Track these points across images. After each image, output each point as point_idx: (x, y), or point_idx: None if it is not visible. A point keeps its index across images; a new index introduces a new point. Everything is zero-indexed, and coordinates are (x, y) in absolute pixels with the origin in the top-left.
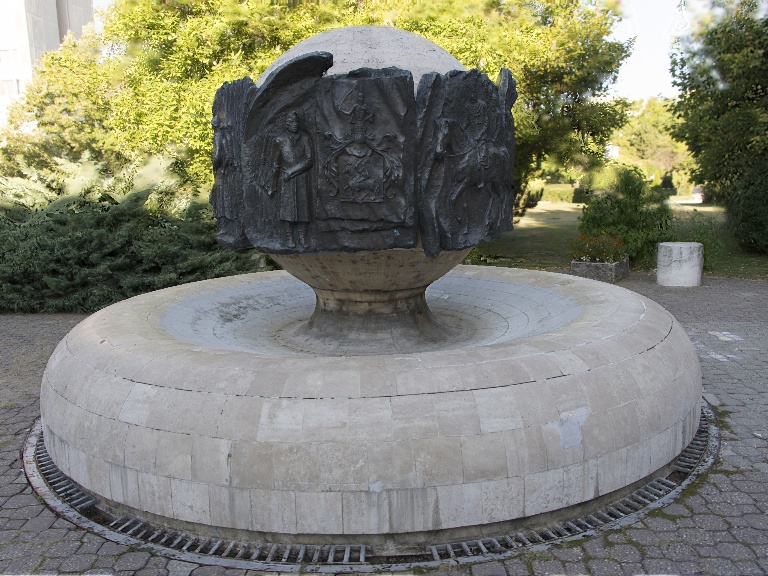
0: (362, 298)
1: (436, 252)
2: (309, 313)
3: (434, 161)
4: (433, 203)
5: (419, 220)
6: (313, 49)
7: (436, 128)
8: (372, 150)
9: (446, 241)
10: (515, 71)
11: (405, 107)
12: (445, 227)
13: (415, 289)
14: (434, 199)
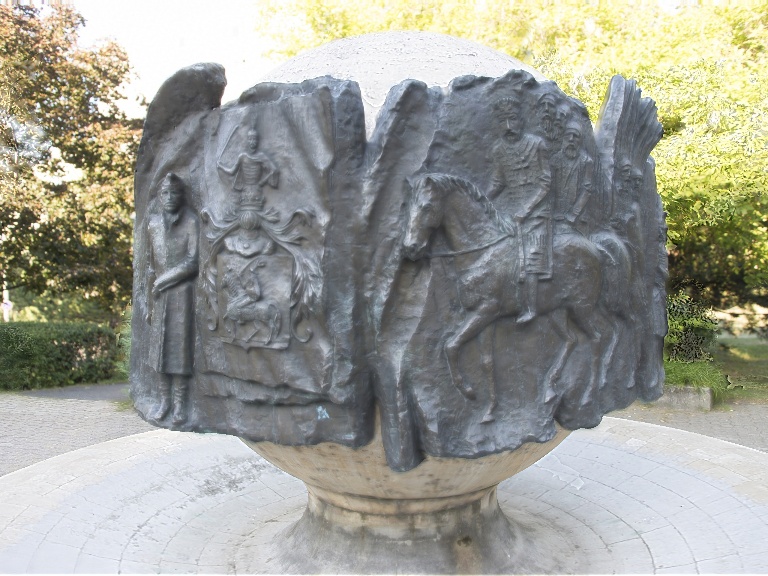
0: (349, 504)
1: (401, 463)
2: None
3: (403, 264)
4: (399, 354)
5: (373, 388)
6: (264, 74)
7: (407, 195)
8: (272, 242)
9: (426, 439)
10: (763, 124)
11: (328, 152)
12: (423, 409)
13: (451, 497)
14: (402, 346)
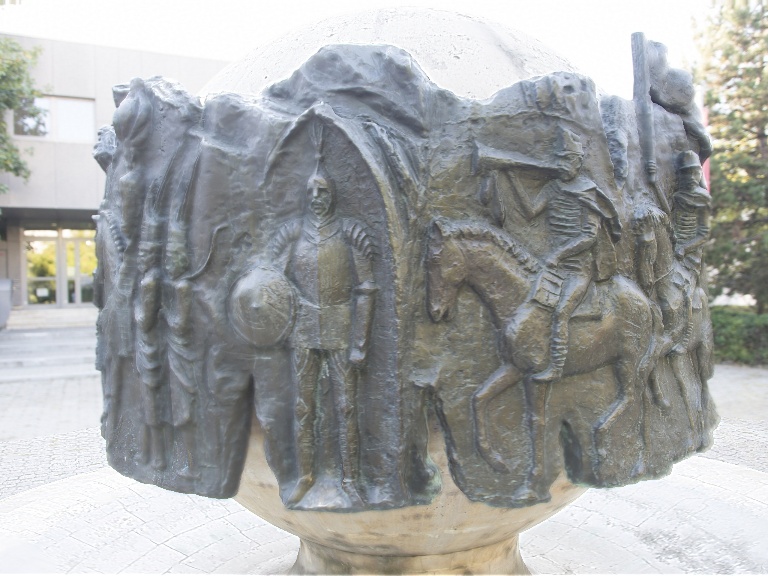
0: None
1: None
2: None
3: None
4: None
5: None
6: None
7: None
8: None
9: None
10: None
11: None
12: None
13: None
14: None
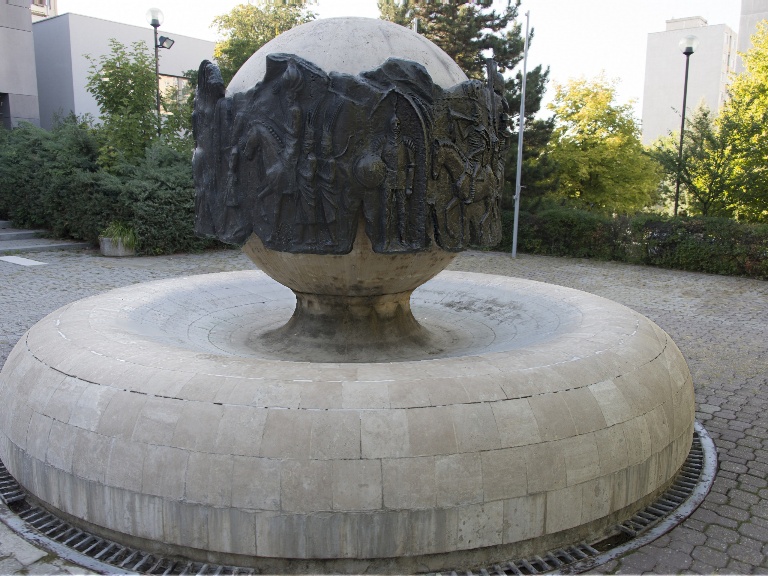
0: None
1: None
2: (470, 334)
3: None
4: None
5: None
6: None
7: None
8: None
9: None
10: None
11: None
12: None
13: None
14: None
